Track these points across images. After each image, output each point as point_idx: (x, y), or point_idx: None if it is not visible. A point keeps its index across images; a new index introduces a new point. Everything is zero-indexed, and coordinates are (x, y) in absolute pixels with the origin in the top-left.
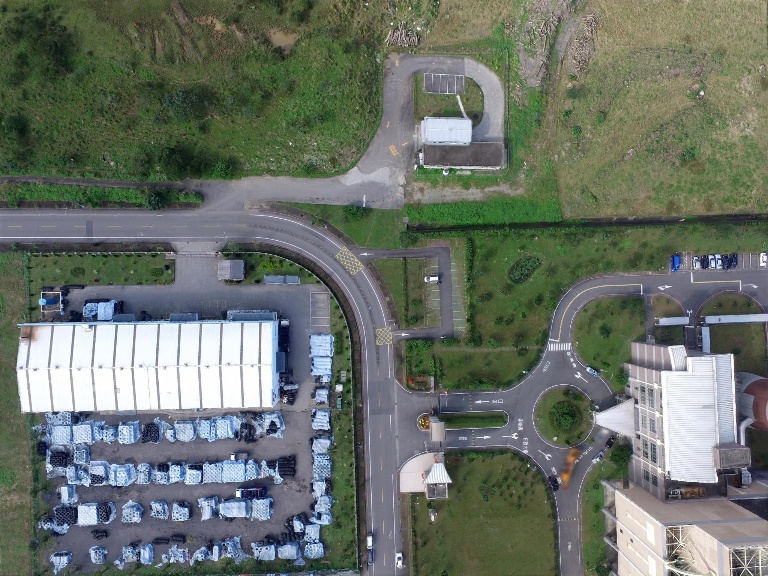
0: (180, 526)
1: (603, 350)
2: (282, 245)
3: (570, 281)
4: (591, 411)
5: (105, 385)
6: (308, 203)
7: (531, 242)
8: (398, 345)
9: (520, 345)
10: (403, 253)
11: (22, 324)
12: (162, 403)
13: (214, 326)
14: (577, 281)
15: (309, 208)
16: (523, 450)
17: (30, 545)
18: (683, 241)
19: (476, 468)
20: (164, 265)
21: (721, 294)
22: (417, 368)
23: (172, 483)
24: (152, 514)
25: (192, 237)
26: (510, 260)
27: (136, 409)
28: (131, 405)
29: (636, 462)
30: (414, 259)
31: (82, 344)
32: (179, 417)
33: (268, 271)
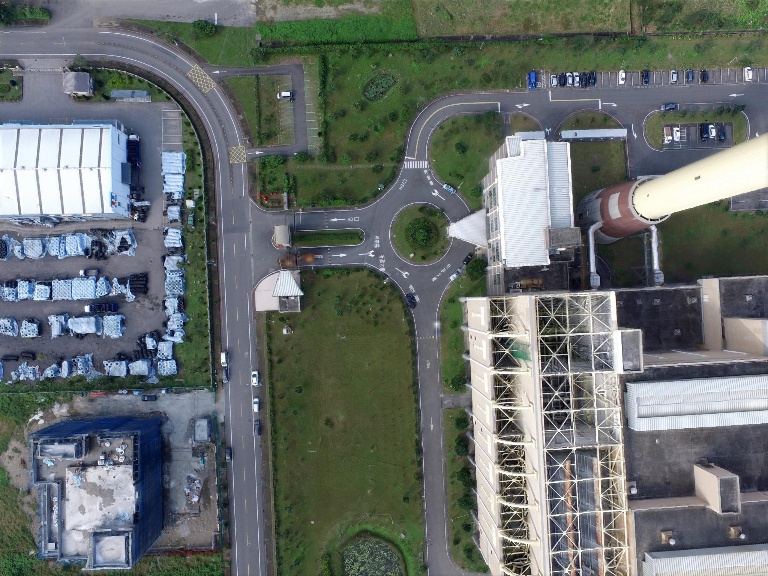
0: (30, 343)
1: (460, 167)
2: (133, 63)
3: (426, 98)
4: None
5: None
6: (158, 20)
7: (386, 59)
8: (252, 163)
9: (376, 162)
10: (256, 71)
11: None
12: (1, 208)
13: (54, 131)
14: (433, 99)
15: (159, 25)
16: (380, 268)
17: None
18: (540, 58)
19: (332, 286)
20: (10, 80)
21: (580, 112)
22: (271, 186)
23: (21, 300)
24: (1, 331)
25: (40, 54)
26: (364, 77)
27: None
28: None
29: (490, 273)
30: (267, 77)
31: None
32: (28, 234)
33: (118, 88)
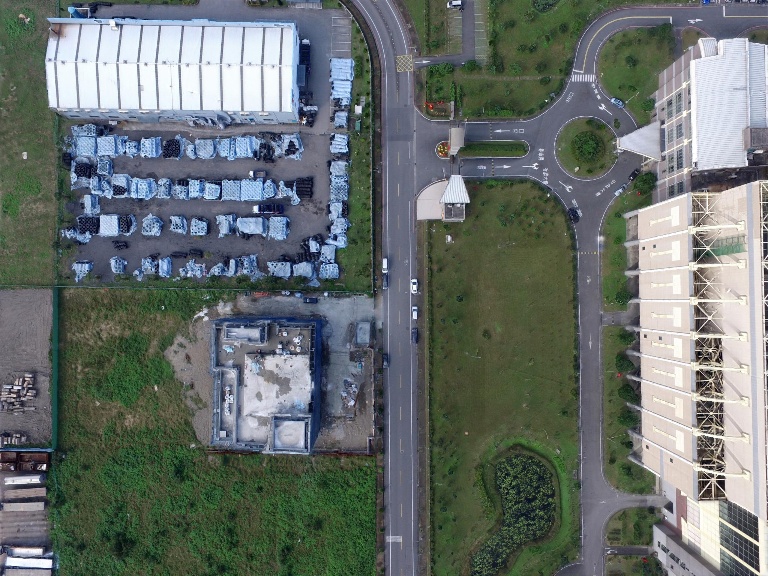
0: (198, 241)
1: (629, 82)
2: None
3: (596, 11)
4: (615, 141)
5: (129, 82)
6: None
7: None
8: (418, 72)
9: (543, 74)
10: None
11: (52, 18)
12: (184, 103)
13: (236, 30)
14: (603, 11)
15: None
16: (543, 181)
17: (54, 244)
18: None
19: (495, 197)
20: None
21: (755, 29)
22: (437, 95)
23: (191, 199)
24: (171, 228)
25: None
26: None
27: (159, 110)
28: (154, 104)
29: (661, 187)
30: None
31: (108, 41)
32: (200, 135)
33: None
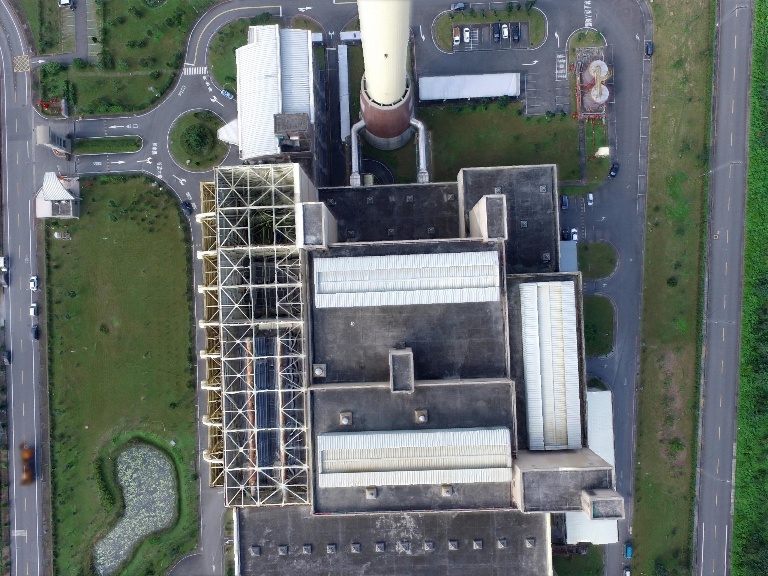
0: None
1: None
2: None
3: (205, 3)
4: None
5: None
6: None
7: None
8: (35, 72)
9: (154, 69)
10: None
11: None
12: None
13: None
14: (213, 4)
15: None
16: (157, 175)
17: None
18: None
19: (110, 193)
20: None
21: None
22: (53, 94)
23: None
24: None
25: None
26: None
27: None
28: None
29: None
30: None
31: None
32: None
33: None
